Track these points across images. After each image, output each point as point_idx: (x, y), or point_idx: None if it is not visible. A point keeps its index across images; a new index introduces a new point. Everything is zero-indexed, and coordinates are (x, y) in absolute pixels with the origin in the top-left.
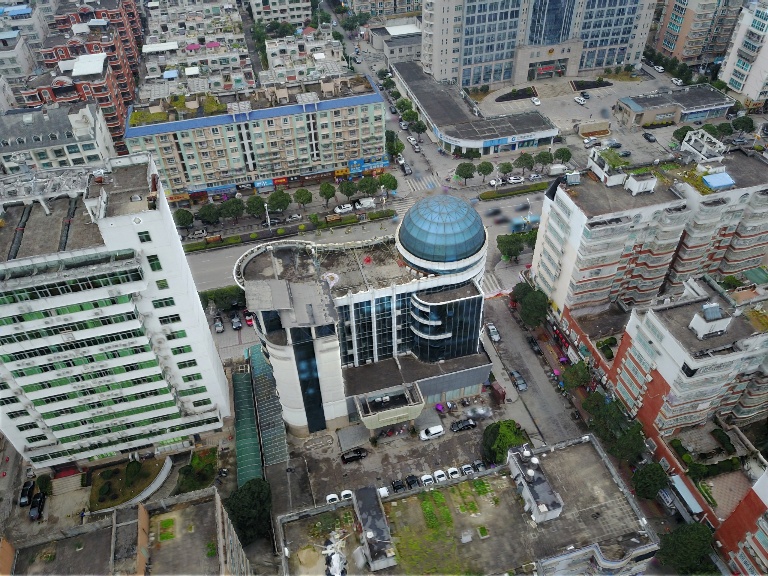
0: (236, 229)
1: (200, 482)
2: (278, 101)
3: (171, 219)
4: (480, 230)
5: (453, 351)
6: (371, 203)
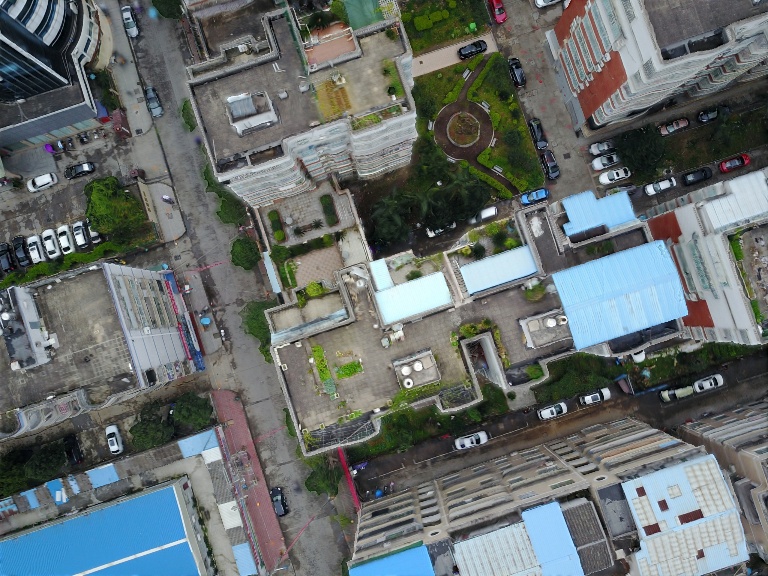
0: None
1: None
2: None
3: None
4: None
5: (27, 89)
6: None
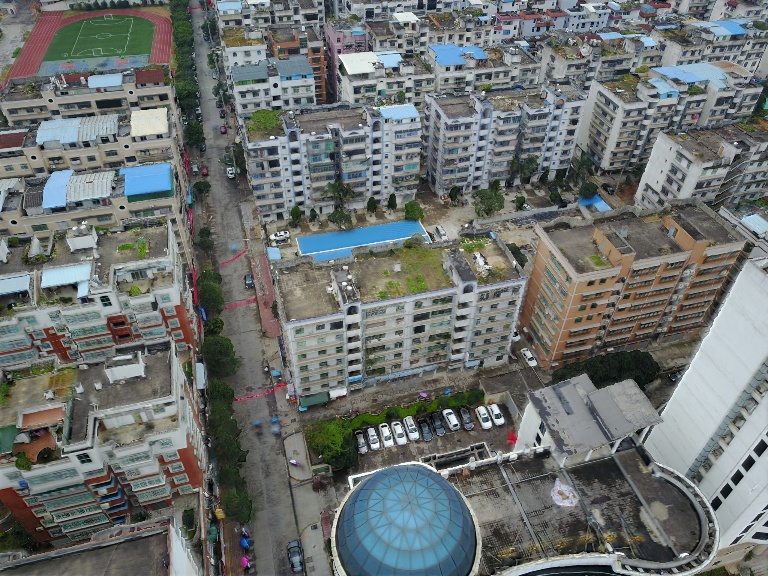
0: None
1: None
2: None
3: (765, 334)
4: None
5: None
6: None
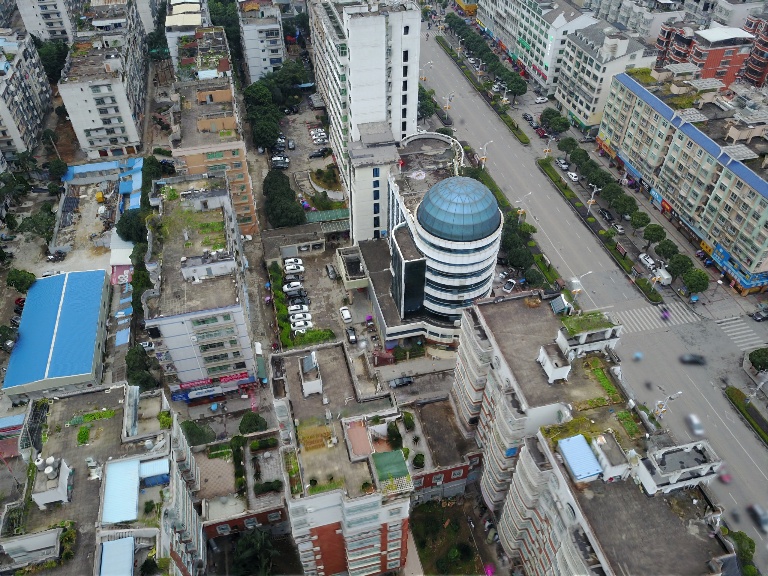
0: (589, 196)
1: (319, 204)
2: (726, 138)
3: (379, 45)
4: (451, 227)
5: None
6: (662, 278)
